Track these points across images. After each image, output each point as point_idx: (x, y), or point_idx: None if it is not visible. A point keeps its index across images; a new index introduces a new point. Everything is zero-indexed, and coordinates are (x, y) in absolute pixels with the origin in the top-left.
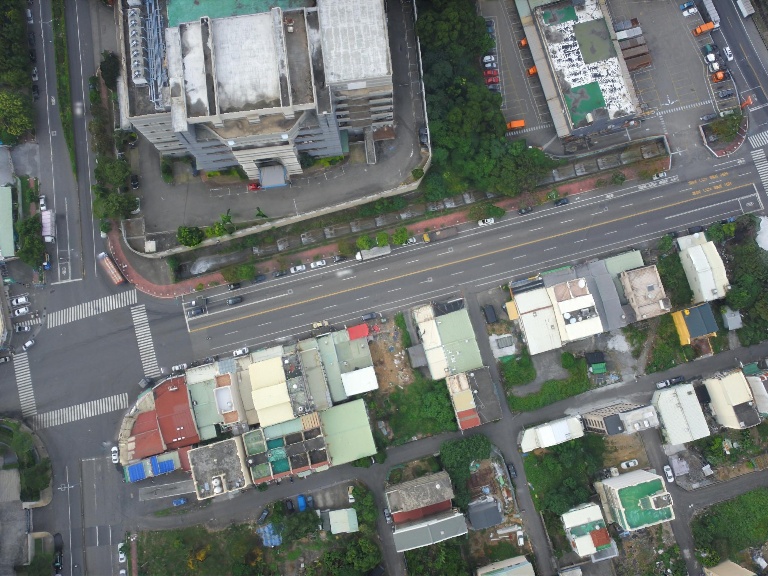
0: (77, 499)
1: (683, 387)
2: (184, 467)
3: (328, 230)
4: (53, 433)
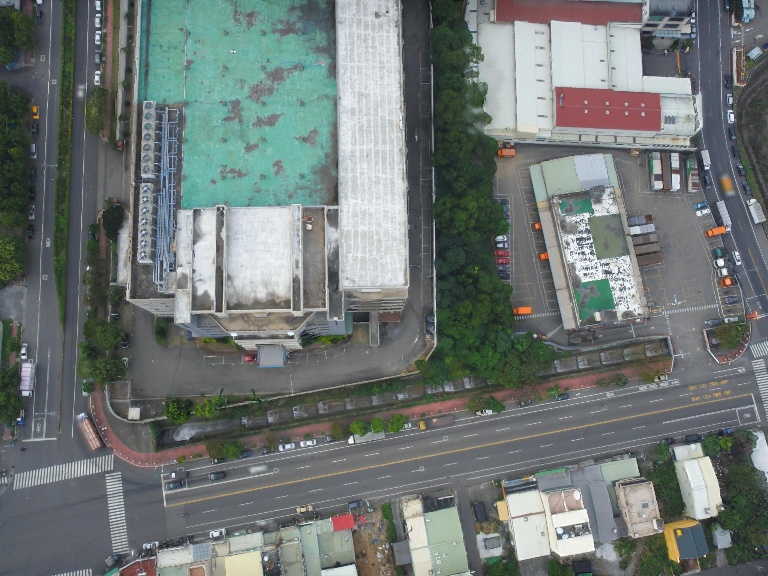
0: None
1: None
2: None
3: (322, 405)
4: None
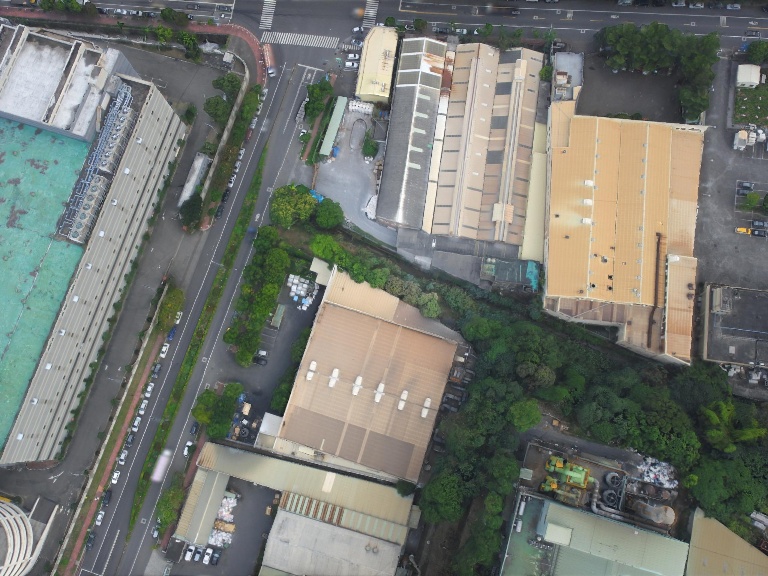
0: None
1: None
2: None
3: None
4: None
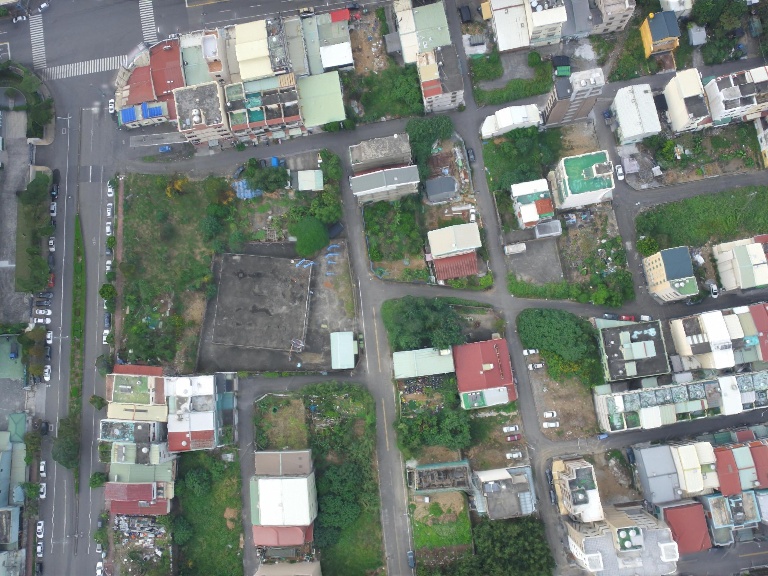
0: (75, 142)
1: (640, 85)
2: (171, 116)
3: None
4: (59, 84)
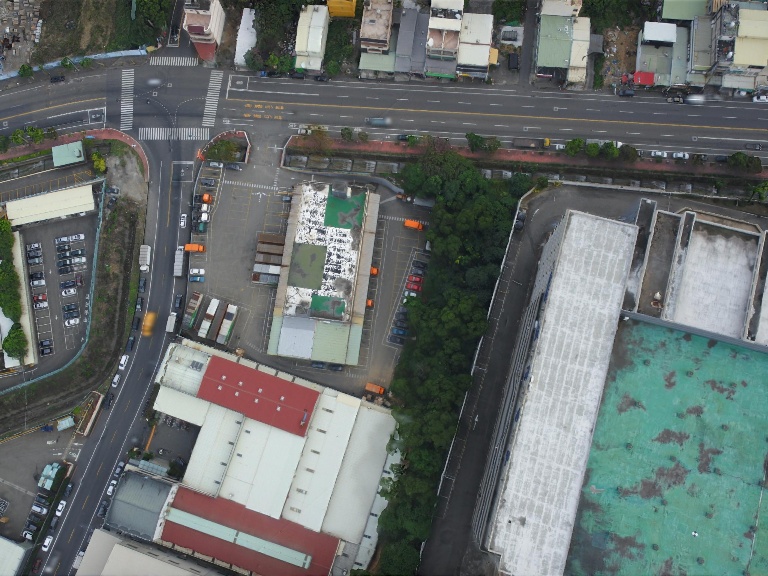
0: None
1: None
2: None
3: None
4: None
